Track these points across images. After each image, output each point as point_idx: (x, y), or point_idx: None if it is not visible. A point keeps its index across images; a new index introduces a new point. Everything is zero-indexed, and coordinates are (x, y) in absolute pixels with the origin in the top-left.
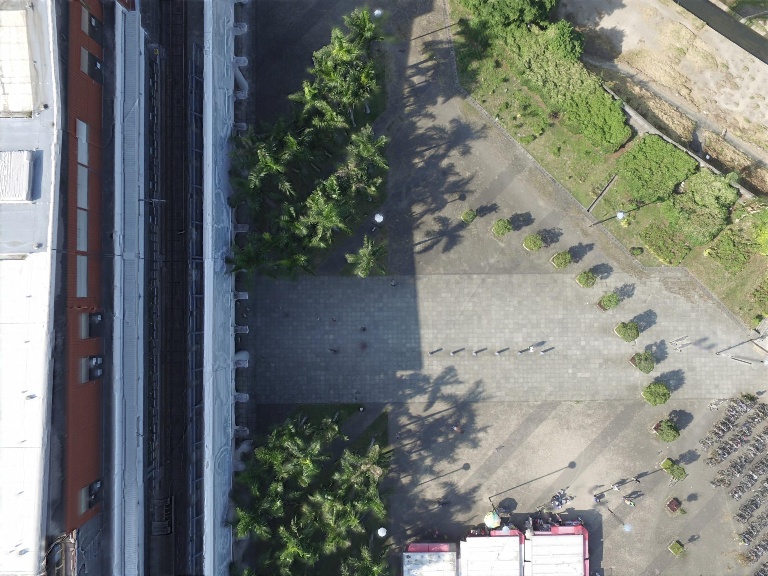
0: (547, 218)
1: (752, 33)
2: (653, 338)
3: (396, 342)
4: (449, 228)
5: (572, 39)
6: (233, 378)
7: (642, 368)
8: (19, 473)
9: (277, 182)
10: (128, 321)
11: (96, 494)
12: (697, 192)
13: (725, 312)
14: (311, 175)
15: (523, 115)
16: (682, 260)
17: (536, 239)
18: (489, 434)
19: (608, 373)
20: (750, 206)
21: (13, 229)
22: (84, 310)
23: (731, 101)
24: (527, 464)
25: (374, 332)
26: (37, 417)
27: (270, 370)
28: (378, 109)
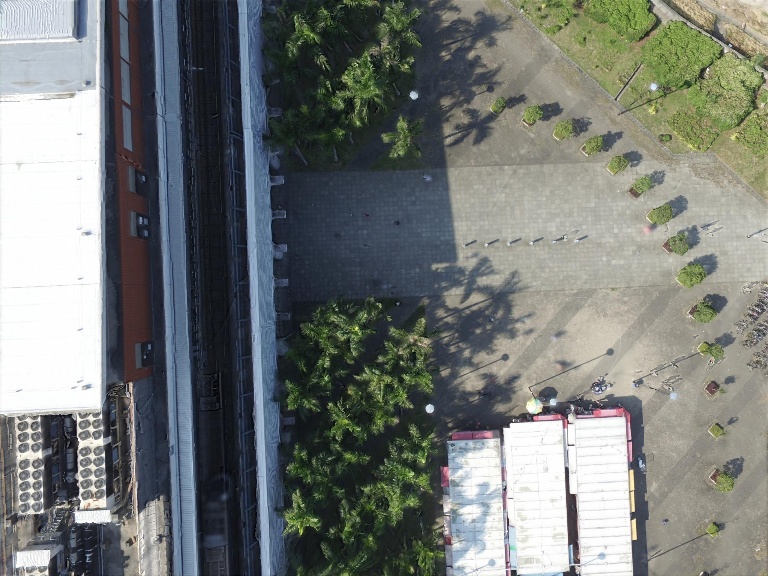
0: (575, 108)
1: None
2: (685, 223)
3: (430, 235)
4: (478, 120)
5: None
6: (272, 264)
7: (677, 249)
8: (77, 310)
9: (313, 55)
10: (172, 184)
11: (148, 356)
12: (723, 76)
13: (754, 196)
14: (344, 54)
15: (548, 6)
16: (710, 146)
17: (567, 123)
18: (526, 324)
19: (642, 260)
20: None
21: (60, 68)
22: (130, 163)
23: None
24: (565, 353)
25: (408, 226)
26: (93, 253)
27: (304, 268)
28: None
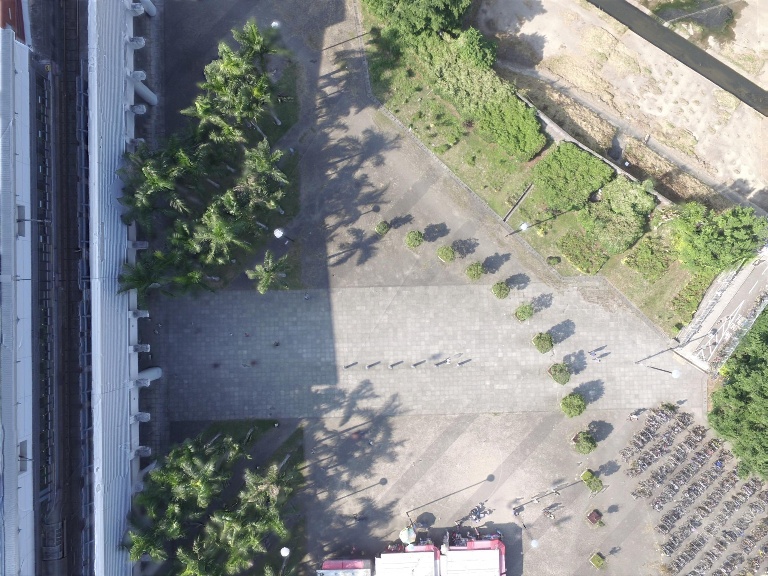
0: (462, 228)
1: (676, 37)
2: (571, 348)
3: (311, 356)
4: (363, 240)
5: (482, 47)
6: (135, 397)
7: (557, 379)
8: None
9: (168, 199)
10: (6, 345)
11: None
12: (613, 200)
13: (644, 321)
14: (209, 191)
15: (437, 124)
16: (600, 269)
17: (447, 251)
18: (406, 448)
19: (526, 384)
20: (665, 214)
21: None
22: None
23: (654, 106)
24: (445, 478)
25: (288, 347)
26: None
27: (183, 387)
28: (290, 121)
